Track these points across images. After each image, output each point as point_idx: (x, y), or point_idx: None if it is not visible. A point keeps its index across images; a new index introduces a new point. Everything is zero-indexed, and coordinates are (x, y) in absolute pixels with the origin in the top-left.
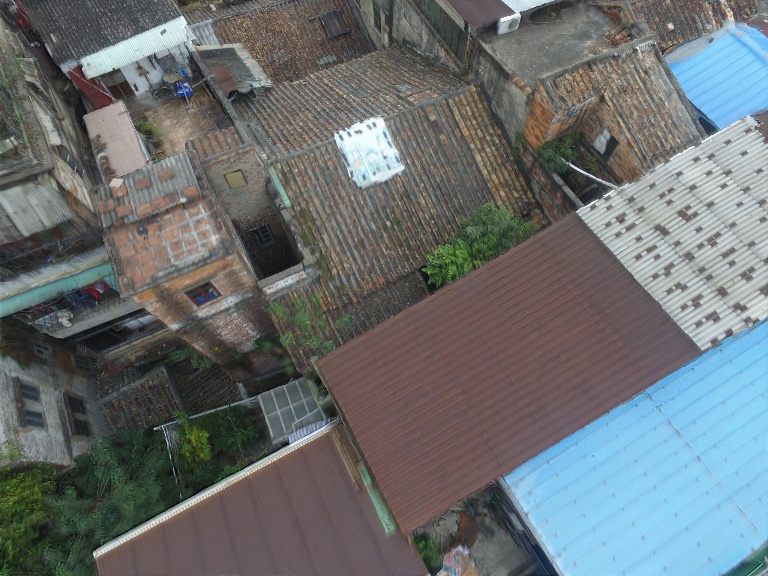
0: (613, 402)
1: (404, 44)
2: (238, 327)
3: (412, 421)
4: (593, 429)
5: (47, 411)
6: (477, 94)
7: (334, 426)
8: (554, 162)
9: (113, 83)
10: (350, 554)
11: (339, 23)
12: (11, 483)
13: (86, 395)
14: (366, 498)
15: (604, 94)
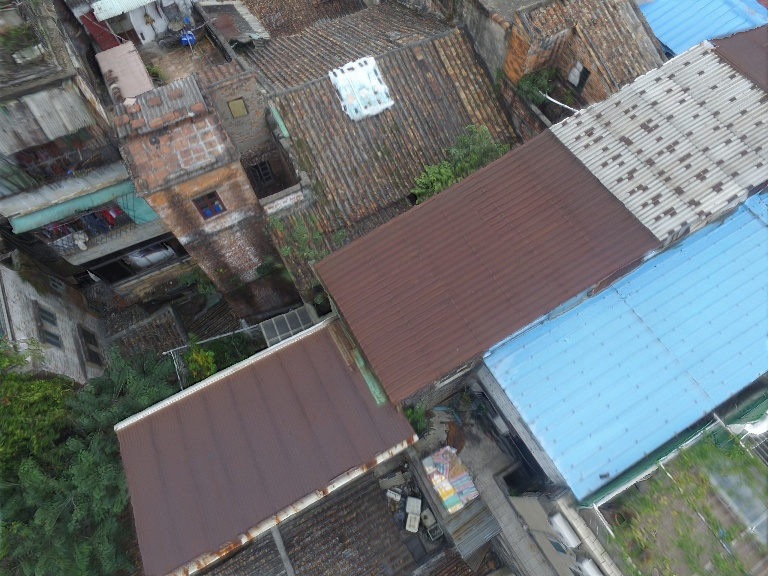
0: (580, 287)
1: (394, 1)
2: (241, 250)
3: (400, 310)
4: (564, 318)
5: (63, 336)
6: (461, 36)
7: (330, 322)
8: (531, 93)
9: (121, 30)
10: (345, 422)
11: None
12: (35, 383)
13: (97, 332)
14: (359, 378)
15: (576, 26)
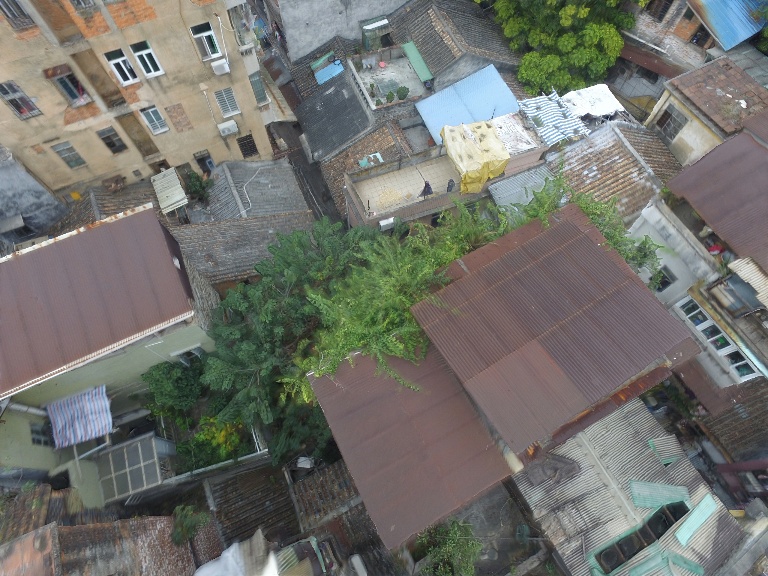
0: None
1: None
2: None
3: None
4: None
5: None
6: None
7: None
8: None
9: None
10: None
11: None
12: None
13: None
14: None
15: None
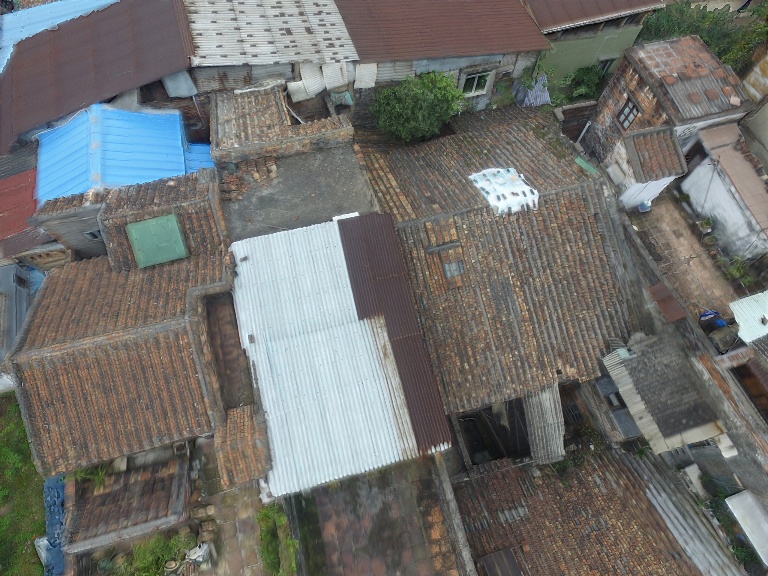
0: None
1: None
2: None
3: (496, 8)
4: None
5: None
6: None
7: None
8: None
9: None
10: None
11: (496, 574)
12: None
13: None
14: None
15: None
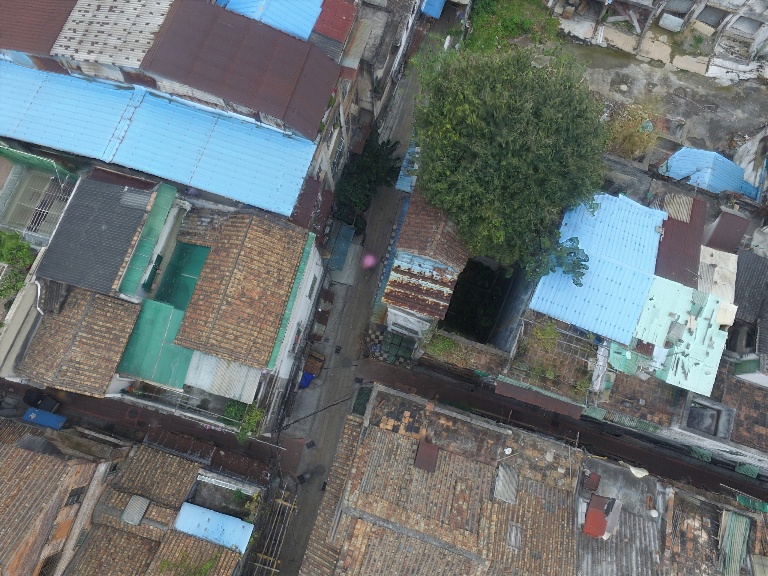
0: None
1: None
2: None
3: None
4: (18, 68)
5: None
6: None
7: None
8: None
9: None
10: None
11: None
12: None
13: None
14: None
15: None
